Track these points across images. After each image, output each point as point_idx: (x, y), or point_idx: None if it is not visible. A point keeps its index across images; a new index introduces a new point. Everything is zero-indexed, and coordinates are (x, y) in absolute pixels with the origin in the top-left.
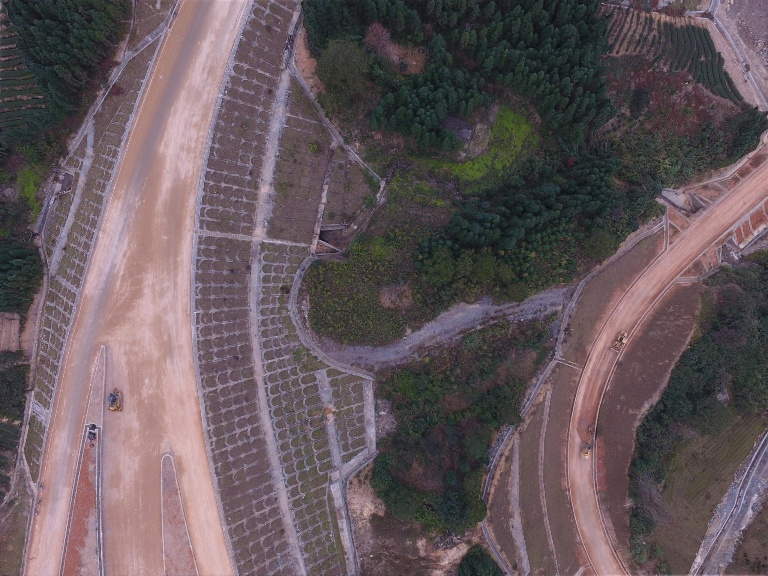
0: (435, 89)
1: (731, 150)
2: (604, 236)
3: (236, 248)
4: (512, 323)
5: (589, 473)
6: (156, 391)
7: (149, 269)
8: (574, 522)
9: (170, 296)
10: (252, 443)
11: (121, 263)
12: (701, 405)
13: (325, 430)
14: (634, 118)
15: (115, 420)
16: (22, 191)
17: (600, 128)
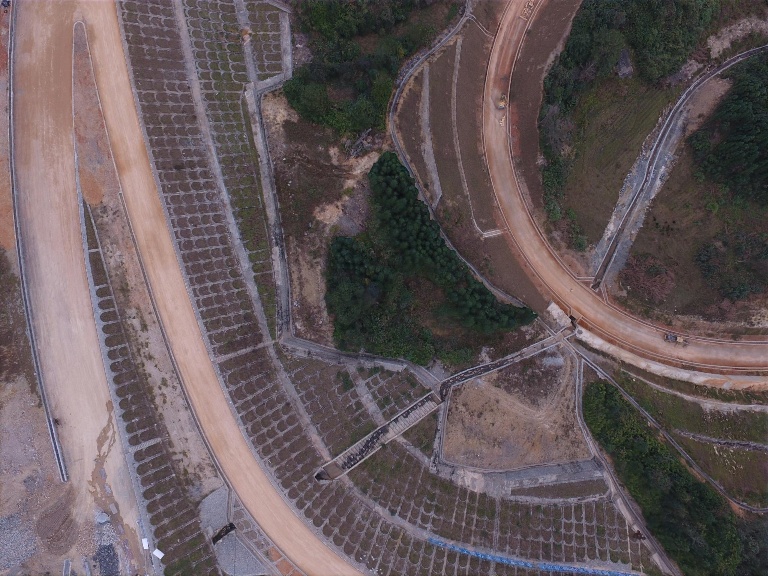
0: None
1: None
2: None
3: None
4: None
5: (504, 140)
6: None
7: None
8: (491, 187)
9: None
10: (165, 31)
11: None
12: (597, 34)
13: (241, 48)
14: None
15: None
16: None
17: None
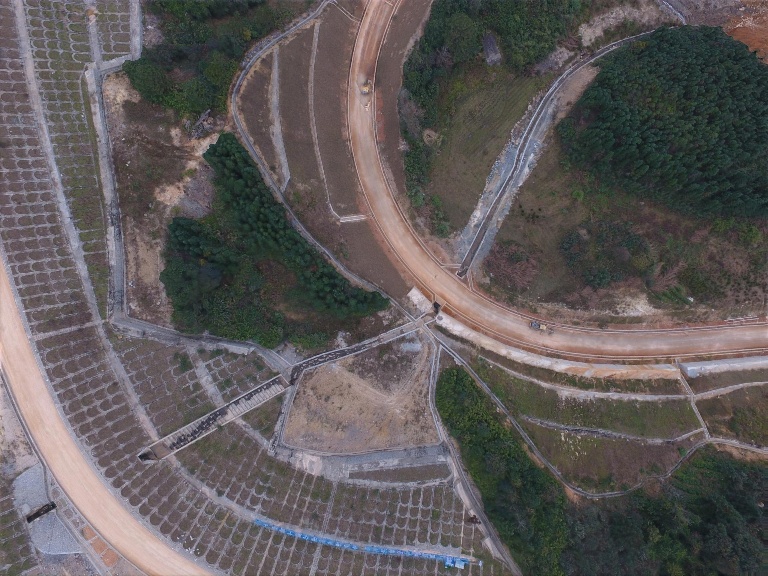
0: None
1: None
2: None
3: None
4: None
5: (370, 126)
6: None
7: None
8: (355, 172)
9: None
10: None
11: None
12: (449, 18)
13: (86, 28)
14: None
15: None
16: None
17: None
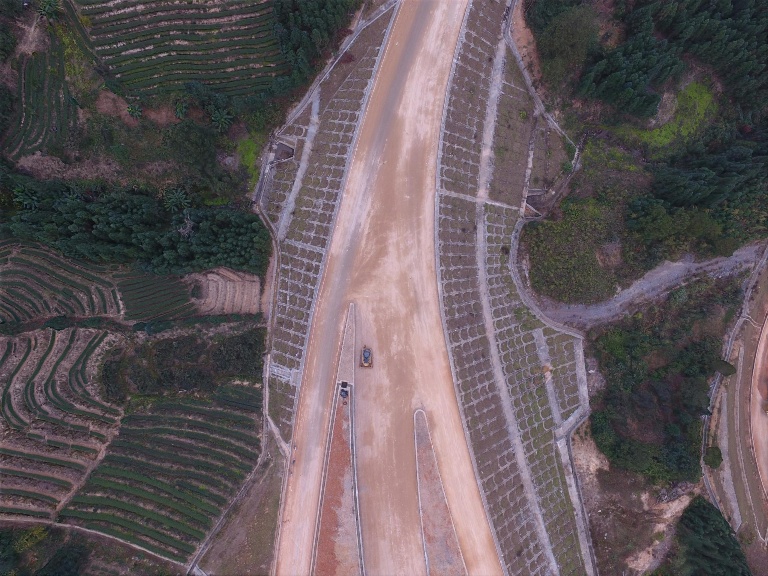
0: (643, 56)
1: None
2: None
3: (465, 208)
4: None
5: None
6: (405, 347)
7: (393, 227)
8: (759, 479)
9: (414, 253)
10: (491, 399)
11: (365, 222)
12: None
13: (545, 388)
14: None
15: (365, 377)
16: (242, 159)
17: None
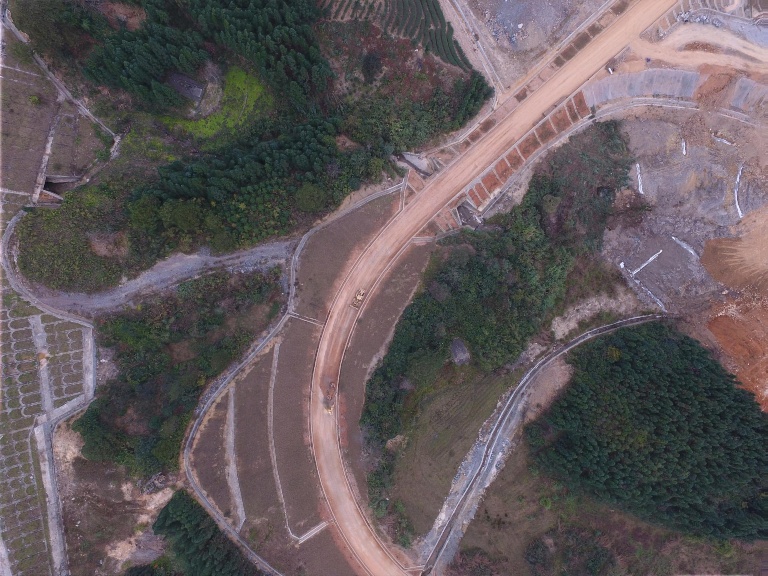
0: None
1: (456, 114)
2: (307, 188)
3: None
4: (233, 274)
5: (333, 429)
6: None
7: None
8: (317, 477)
9: None
10: None
11: None
12: (411, 356)
13: (36, 375)
14: (368, 82)
15: None
16: None
17: (336, 91)
